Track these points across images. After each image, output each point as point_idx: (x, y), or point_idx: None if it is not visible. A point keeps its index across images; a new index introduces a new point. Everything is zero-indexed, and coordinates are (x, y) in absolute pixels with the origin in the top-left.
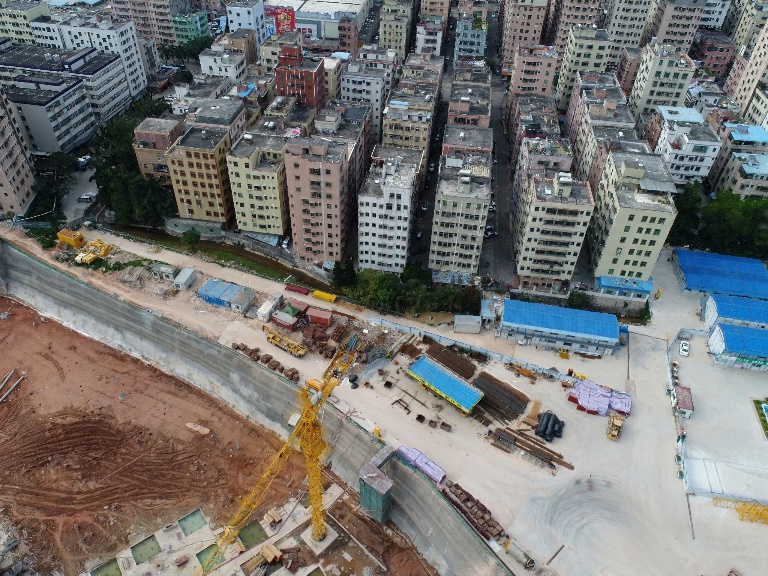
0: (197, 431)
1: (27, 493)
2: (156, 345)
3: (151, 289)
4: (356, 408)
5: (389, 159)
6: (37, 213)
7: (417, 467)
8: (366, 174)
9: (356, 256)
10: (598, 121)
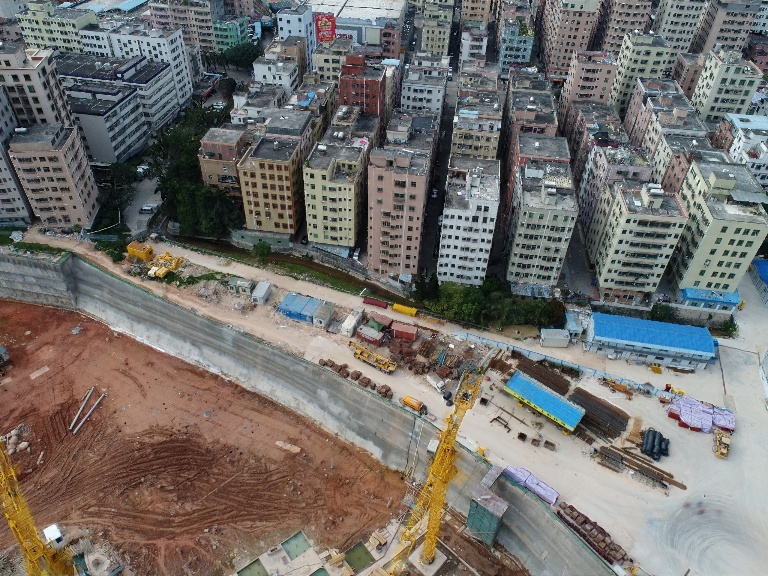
0: (288, 450)
1: (124, 516)
2: (236, 361)
3: (228, 303)
4: None
5: (473, 171)
6: (104, 226)
7: (527, 488)
8: (447, 186)
9: (429, 268)
10: (669, 129)
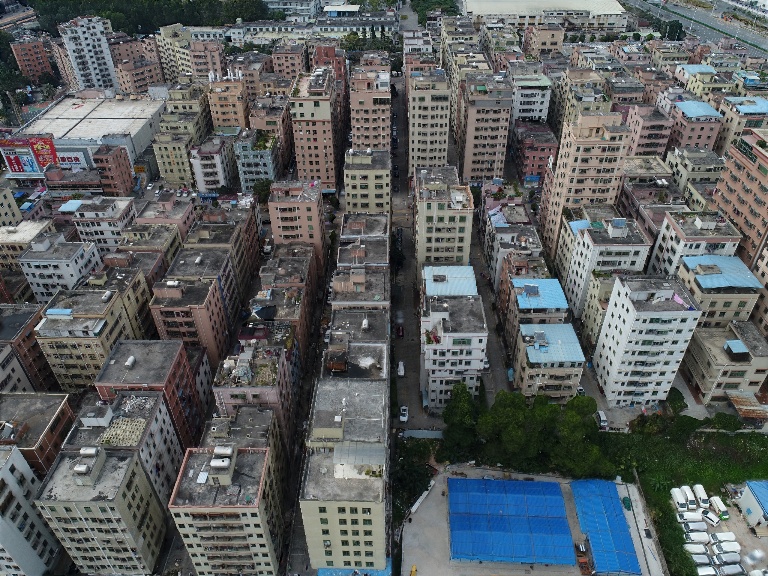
0: None
1: None
2: None
3: None
4: None
5: None
6: None
7: None
8: None
9: None
10: (341, 302)
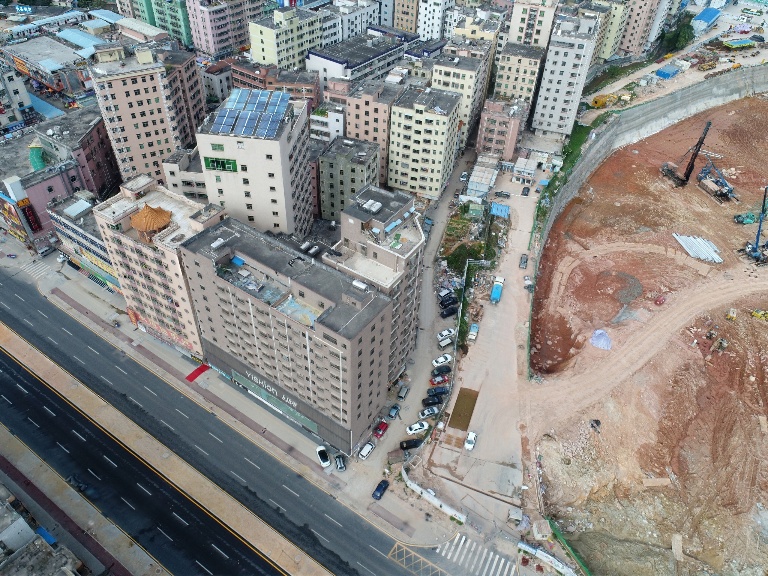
0: None
1: None
2: (681, 108)
3: None
4: (747, 64)
5: None
6: None
7: None
8: None
9: None
10: None
